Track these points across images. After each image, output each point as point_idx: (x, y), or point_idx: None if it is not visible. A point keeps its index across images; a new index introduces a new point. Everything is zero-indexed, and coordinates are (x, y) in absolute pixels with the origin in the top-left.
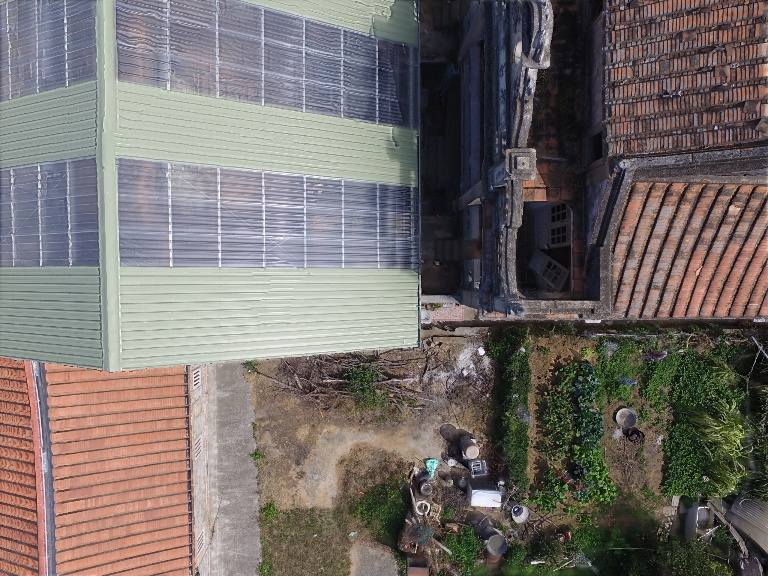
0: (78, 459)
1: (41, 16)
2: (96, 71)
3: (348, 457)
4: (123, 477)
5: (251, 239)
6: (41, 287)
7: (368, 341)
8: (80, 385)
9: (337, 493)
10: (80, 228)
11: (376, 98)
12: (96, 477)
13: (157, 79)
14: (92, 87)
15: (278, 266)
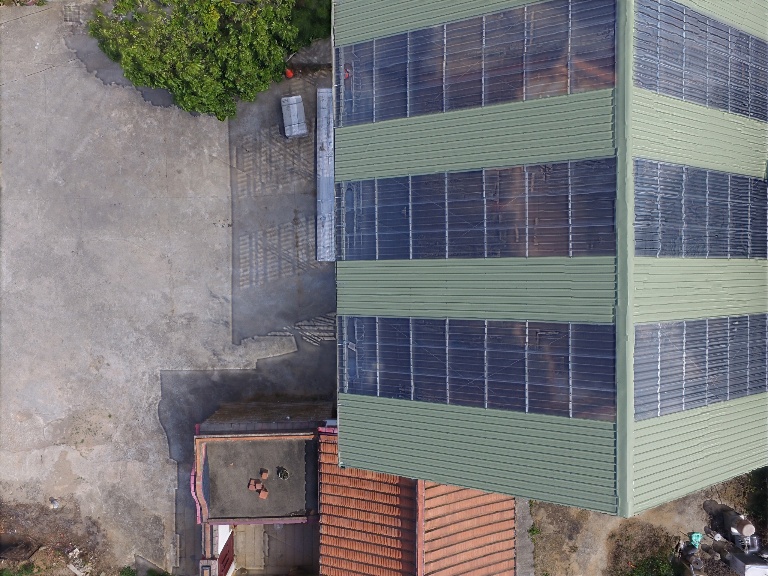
0: (439, 555)
1: (533, 189)
2: (616, 249)
3: (618, 532)
4: (468, 568)
5: (699, 381)
6: (527, 431)
7: (760, 459)
8: (444, 487)
9: (607, 566)
10: (587, 385)
11: (767, 236)
12: (451, 570)
13: (652, 249)
14: (607, 261)
15: (713, 402)
